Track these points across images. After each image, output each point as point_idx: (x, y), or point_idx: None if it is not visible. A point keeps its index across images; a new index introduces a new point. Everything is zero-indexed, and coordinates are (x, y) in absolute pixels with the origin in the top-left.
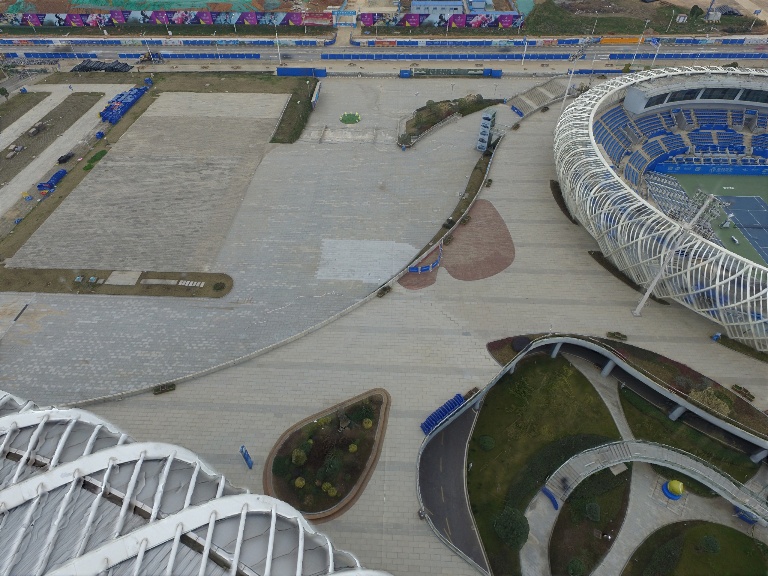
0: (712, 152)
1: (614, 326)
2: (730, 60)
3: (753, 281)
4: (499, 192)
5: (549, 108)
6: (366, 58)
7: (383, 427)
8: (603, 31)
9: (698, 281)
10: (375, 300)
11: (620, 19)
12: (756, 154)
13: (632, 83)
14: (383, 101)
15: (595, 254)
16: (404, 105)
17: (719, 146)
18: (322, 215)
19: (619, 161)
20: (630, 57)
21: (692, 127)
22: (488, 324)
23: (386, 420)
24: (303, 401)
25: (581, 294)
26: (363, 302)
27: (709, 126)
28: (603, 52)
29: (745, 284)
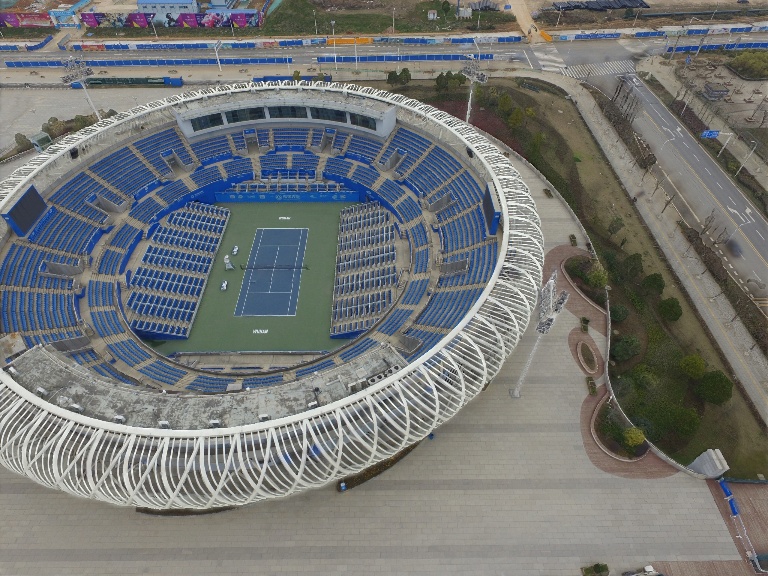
0: (281, 177)
1: None
2: (445, 62)
3: None
4: None
5: (146, 127)
6: (56, 65)
7: None
8: (342, 30)
9: None
10: None
11: (367, 16)
12: (329, 178)
13: (174, 103)
14: (25, 117)
15: None
16: (43, 122)
17: (289, 170)
18: None
19: (131, 195)
20: (340, 60)
21: (267, 149)
22: None
23: None
24: None
25: None
26: None
27: (286, 147)
28: (320, 54)
29: None
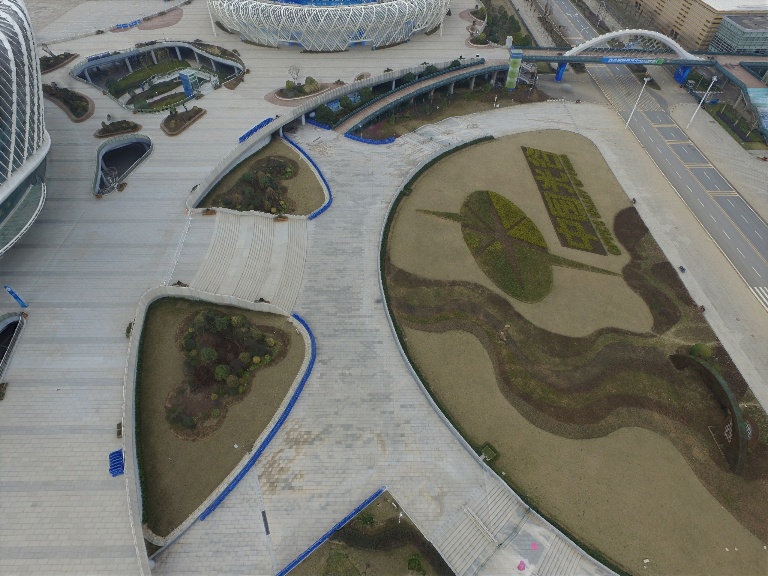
0: None
1: (201, 39)
2: None
3: (235, 2)
4: (191, 6)
5: None
6: None
7: (71, 61)
8: None
9: (221, 8)
10: (94, 35)
11: None
12: None
13: None
14: None
15: (217, 22)
16: None
17: None
18: (98, 24)
19: None
20: None
21: None
22: (142, 40)
23: (73, 60)
24: (40, 57)
25: (196, 32)
26: (87, 35)
27: None
28: None
29: (232, 3)
